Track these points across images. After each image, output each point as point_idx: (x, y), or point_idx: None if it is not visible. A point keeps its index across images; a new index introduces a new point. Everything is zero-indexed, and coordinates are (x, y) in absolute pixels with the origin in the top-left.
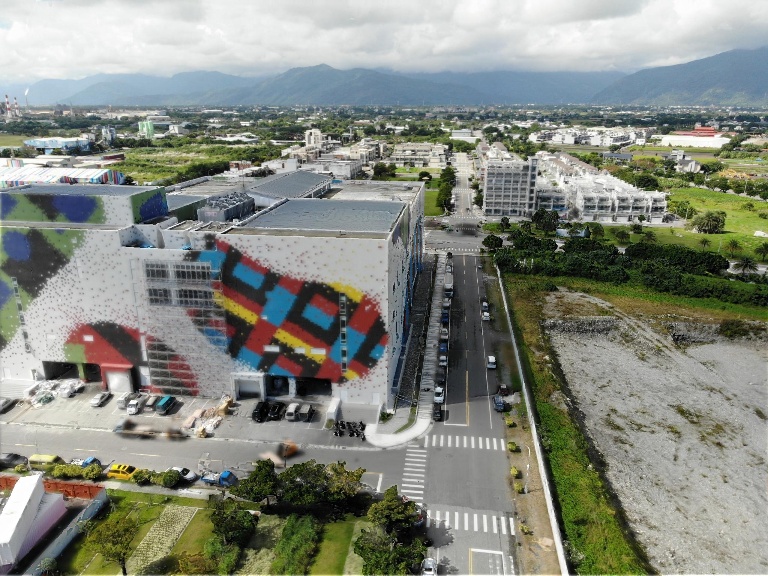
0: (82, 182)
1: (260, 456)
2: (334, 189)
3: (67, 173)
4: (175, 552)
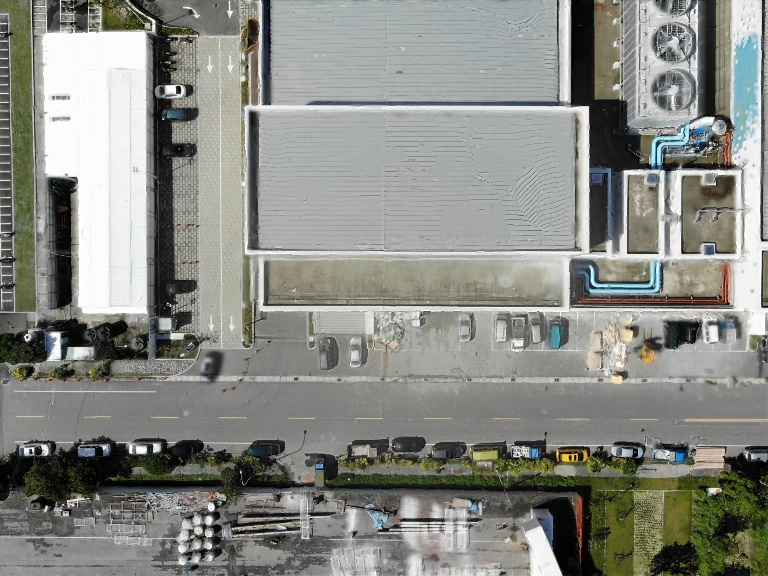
0: None
1: (691, 406)
2: None
3: None
4: (668, 544)
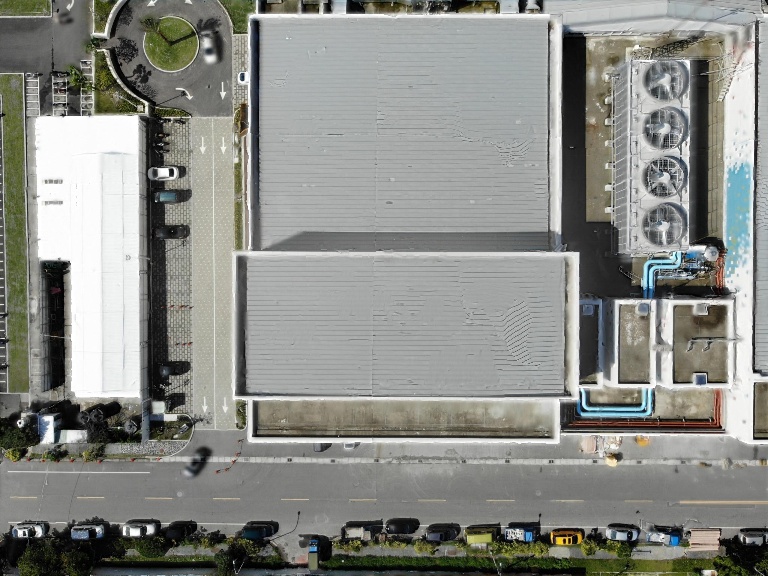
0: None
1: (686, 488)
2: None
3: None
4: None
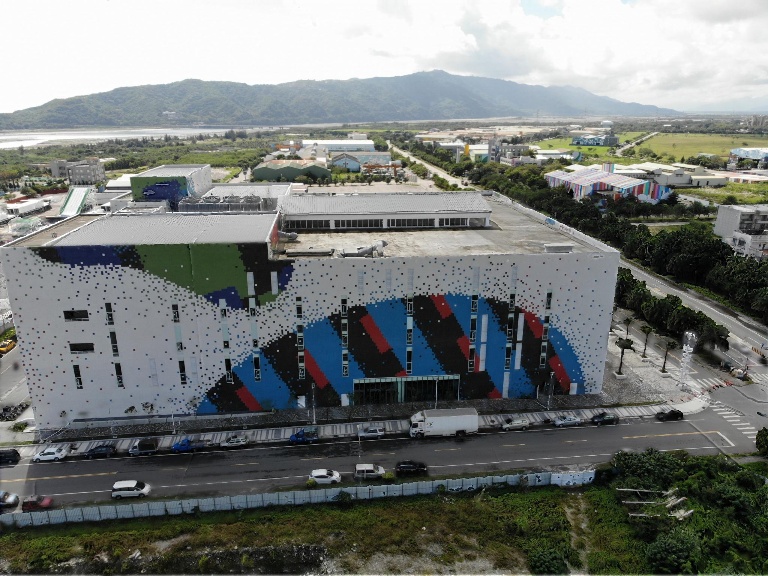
0: (615, 191)
1: None
2: (489, 227)
3: (616, 180)
4: None
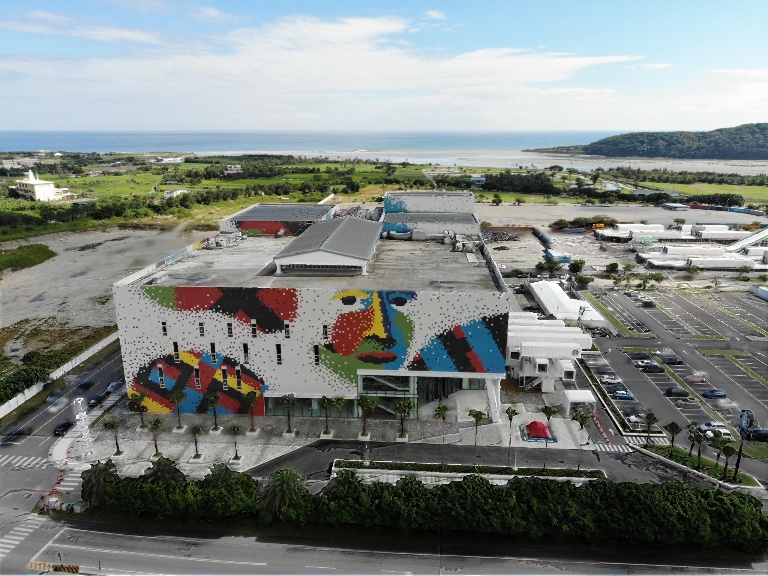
0: None
1: None
2: (273, 273)
3: None
4: None
